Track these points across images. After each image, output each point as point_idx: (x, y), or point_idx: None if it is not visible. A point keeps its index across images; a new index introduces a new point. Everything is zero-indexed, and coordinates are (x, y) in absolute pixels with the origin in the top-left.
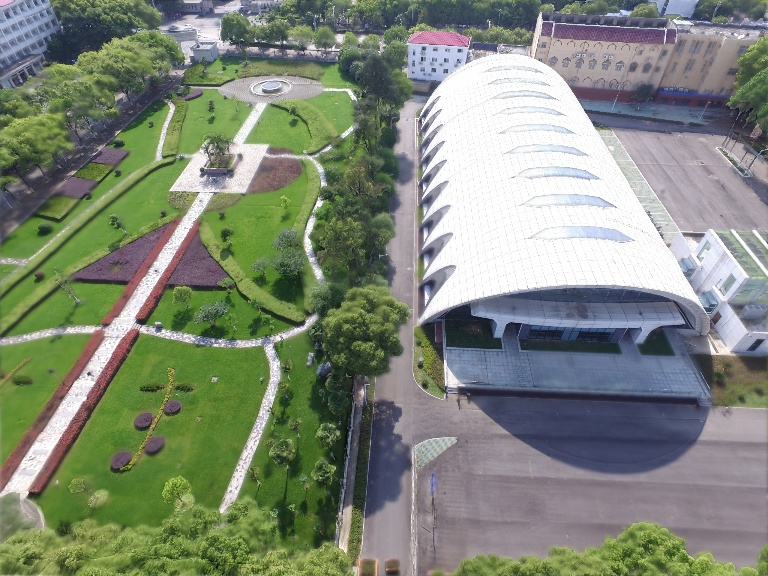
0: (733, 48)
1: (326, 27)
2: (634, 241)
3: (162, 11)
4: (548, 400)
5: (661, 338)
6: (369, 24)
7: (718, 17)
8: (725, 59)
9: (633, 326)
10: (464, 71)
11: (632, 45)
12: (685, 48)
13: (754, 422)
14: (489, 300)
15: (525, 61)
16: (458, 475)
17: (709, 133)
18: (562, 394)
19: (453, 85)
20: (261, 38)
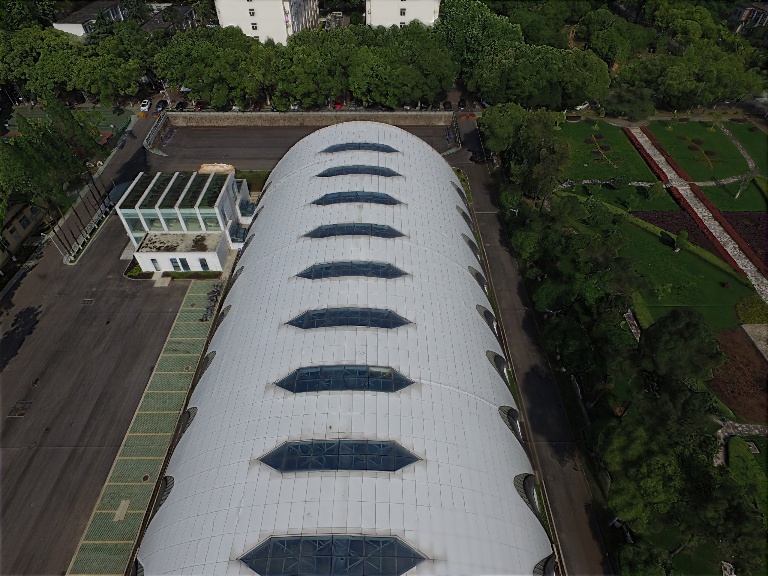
0: None
1: None
2: None
3: None
4: None
5: None
6: None
7: None
8: None
9: None
10: None
11: None
12: None
13: (273, 165)
14: None
15: None
16: (437, 146)
17: None
18: None
19: None
20: None
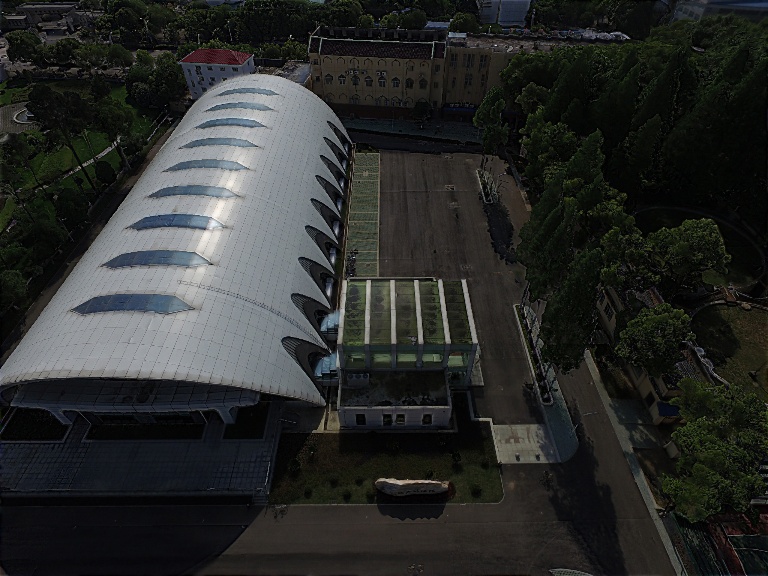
0: (502, 62)
1: (118, 45)
2: (192, 310)
3: None
4: (76, 508)
5: (260, 415)
6: None
7: (537, 25)
8: (498, 73)
9: (200, 408)
10: (206, 94)
11: (401, 61)
12: (458, 62)
13: (304, 525)
14: (38, 384)
15: (268, 82)
16: None
17: (480, 153)
18: (97, 499)
19: (190, 110)
20: (53, 58)
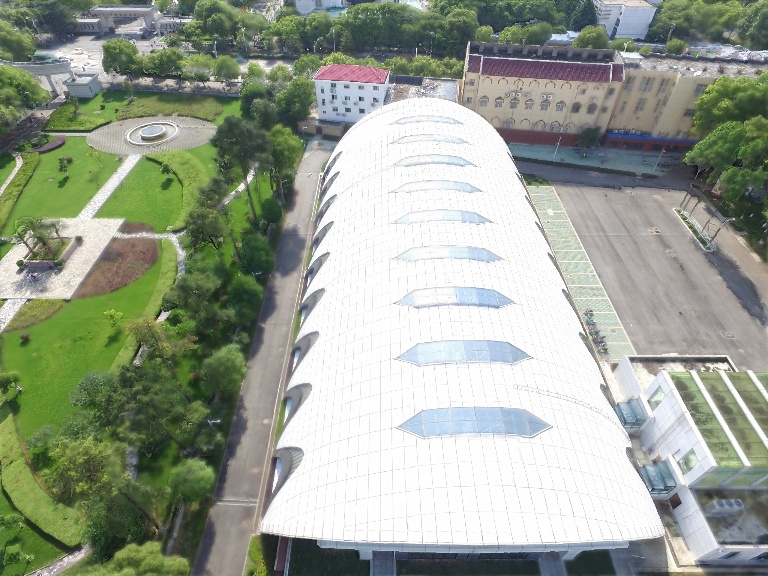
0: (689, 87)
1: (226, 56)
2: (551, 428)
3: (50, 32)
4: None
5: None
6: (288, 47)
7: (673, 40)
8: (680, 99)
9: (554, 550)
10: (370, 120)
11: (573, 83)
12: (635, 86)
13: None
14: None
15: (443, 108)
16: None
17: (665, 187)
18: None
19: (356, 139)
20: (152, 68)
